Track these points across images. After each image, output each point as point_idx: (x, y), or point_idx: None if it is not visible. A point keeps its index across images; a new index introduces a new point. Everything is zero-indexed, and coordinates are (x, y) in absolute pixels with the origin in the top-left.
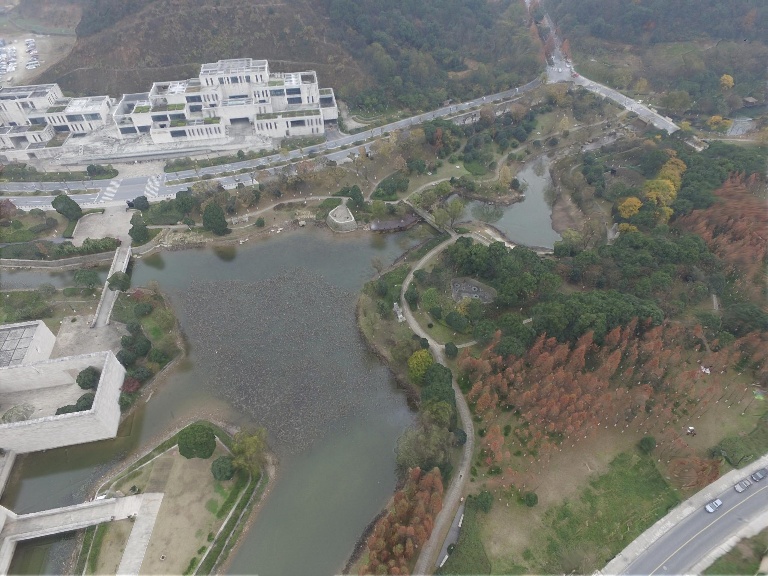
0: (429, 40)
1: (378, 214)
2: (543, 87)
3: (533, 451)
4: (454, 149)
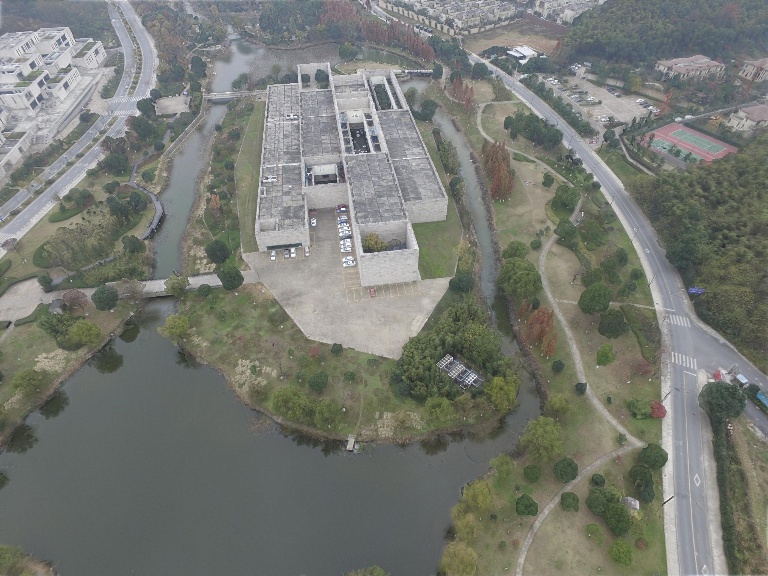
0: None
1: None
2: None
3: None
4: None
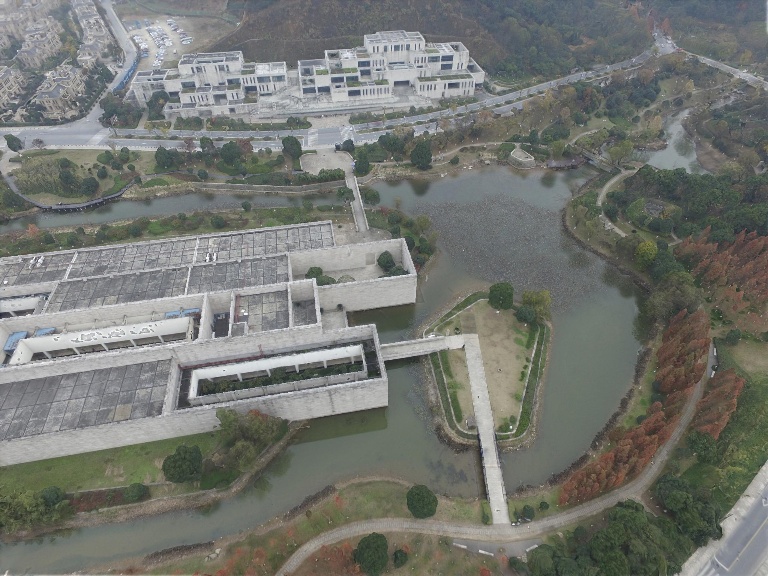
0: (549, 17)
1: (558, 152)
2: (662, 57)
3: (754, 310)
4: (598, 106)
